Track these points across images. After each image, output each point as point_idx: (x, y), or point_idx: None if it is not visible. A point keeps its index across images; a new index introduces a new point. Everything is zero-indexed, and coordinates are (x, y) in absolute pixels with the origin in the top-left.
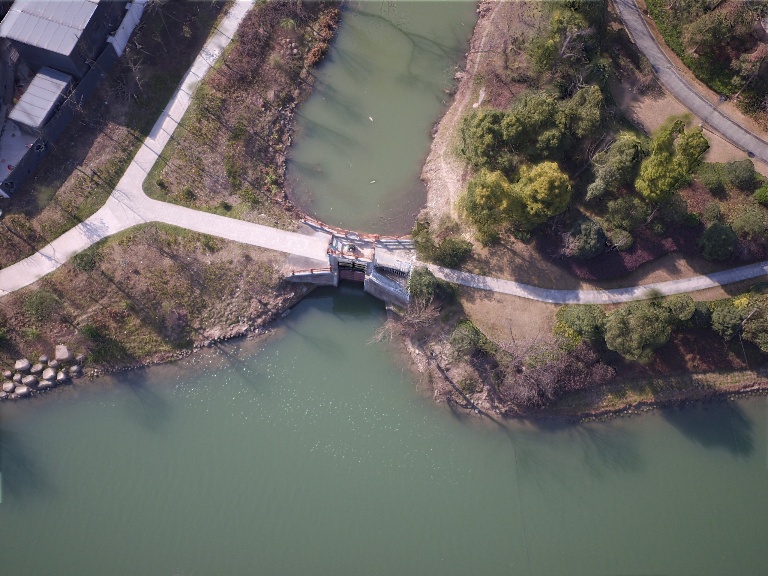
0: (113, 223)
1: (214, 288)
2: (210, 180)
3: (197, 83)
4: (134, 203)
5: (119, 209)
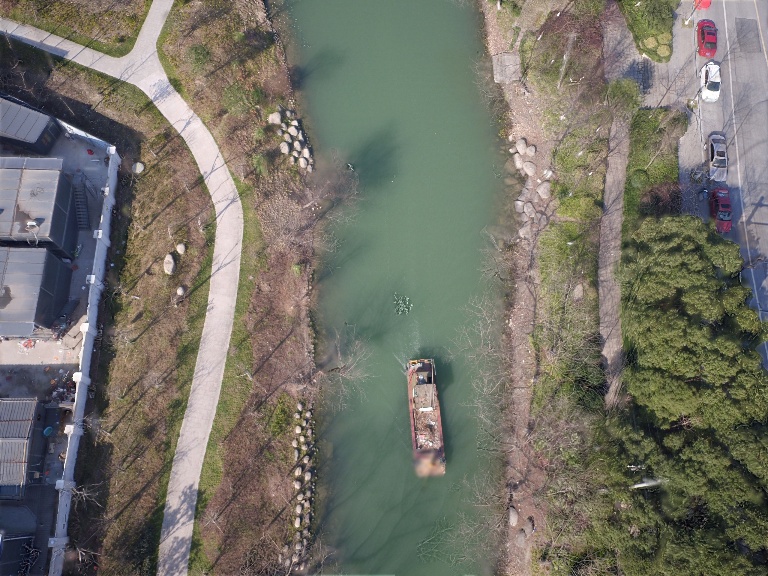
0: (155, 77)
1: (223, 3)
2: (117, 6)
3: (6, 20)
4: (136, 62)
5: (141, 73)
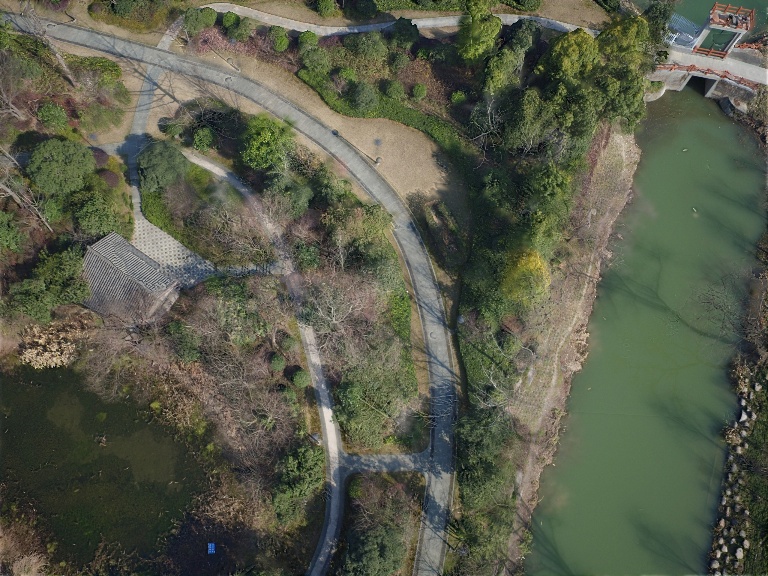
0: None
1: None
2: None
3: None
4: None
5: None
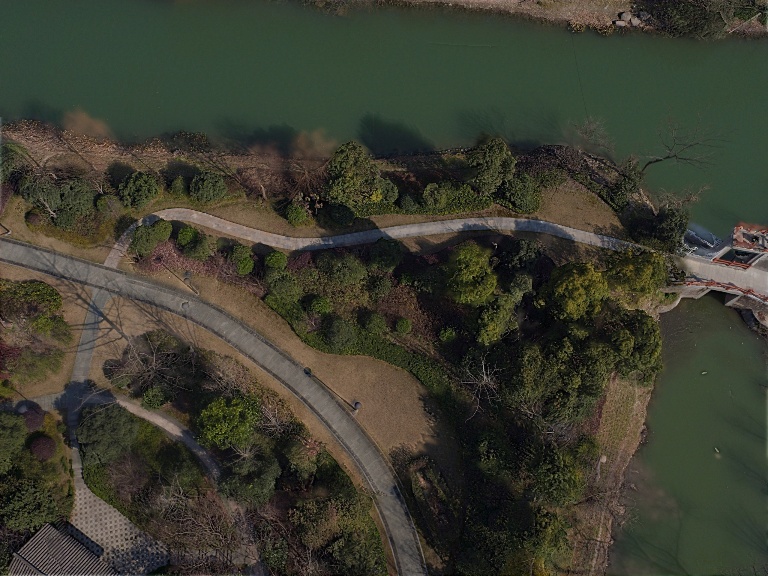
0: None
1: None
2: None
3: None
4: None
5: None
